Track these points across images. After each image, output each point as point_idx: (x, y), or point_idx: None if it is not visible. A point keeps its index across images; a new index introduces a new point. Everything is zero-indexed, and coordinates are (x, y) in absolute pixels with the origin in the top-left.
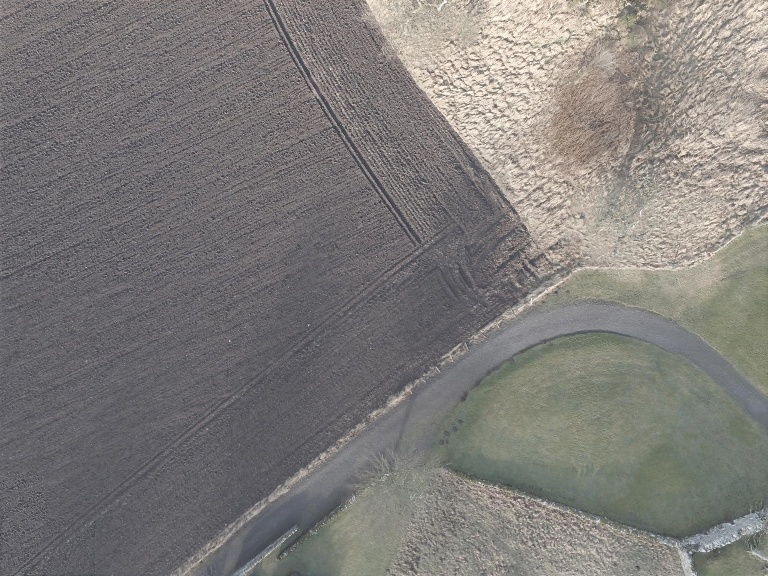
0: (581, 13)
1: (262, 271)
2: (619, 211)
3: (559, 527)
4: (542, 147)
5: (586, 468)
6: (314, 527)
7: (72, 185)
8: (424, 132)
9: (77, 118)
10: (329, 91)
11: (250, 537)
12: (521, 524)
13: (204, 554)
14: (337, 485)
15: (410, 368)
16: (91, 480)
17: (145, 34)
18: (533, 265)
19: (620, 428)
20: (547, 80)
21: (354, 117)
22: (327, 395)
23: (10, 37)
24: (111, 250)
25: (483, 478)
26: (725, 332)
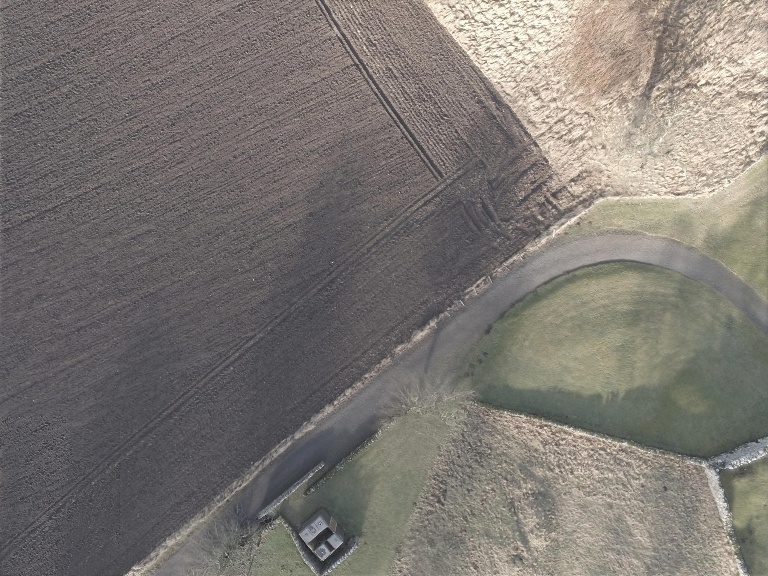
0: None
1: (285, 209)
2: (640, 140)
3: (586, 452)
4: (563, 78)
5: (611, 394)
6: (340, 463)
7: (93, 128)
8: (445, 67)
9: (97, 61)
10: (350, 29)
11: (276, 475)
12: (548, 452)
13: (230, 492)
14: (363, 421)
15: (434, 303)
16: (115, 421)
17: None
18: (555, 198)
19: (644, 353)
20: (568, 11)
21: (375, 54)
22: (352, 331)
23: None
24: (133, 192)
25: (509, 408)
26: (746, 257)
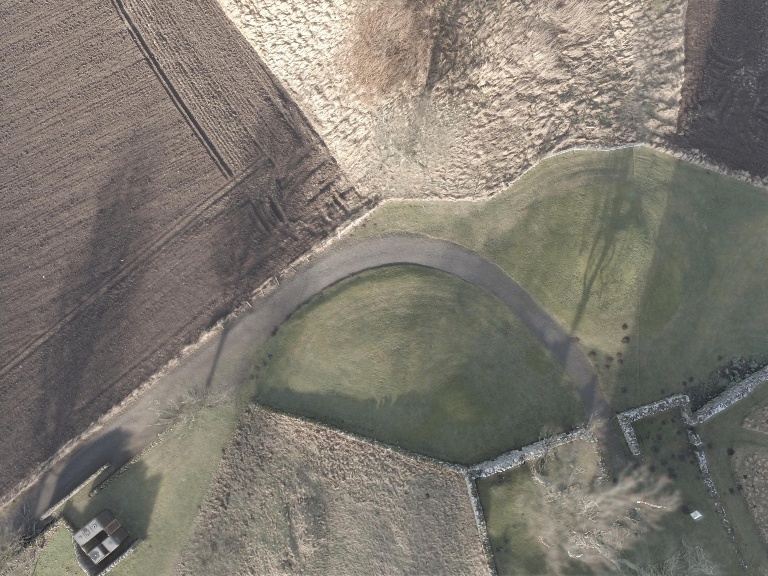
0: None
1: (76, 206)
2: None
3: (357, 458)
4: (345, 77)
5: (385, 399)
6: (125, 464)
7: None
8: (233, 63)
9: None
10: (141, 22)
11: (63, 476)
12: (323, 456)
13: (16, 493)
14: (150, 422)
15: (222, 303)
16: None
17: None
18: (343, 198)
19: (418, 358)
20: (347, 8)
21: (165, 48)
22: (140, 331)
23: None
24: None
25: (288, 411)
26: (522, 262)
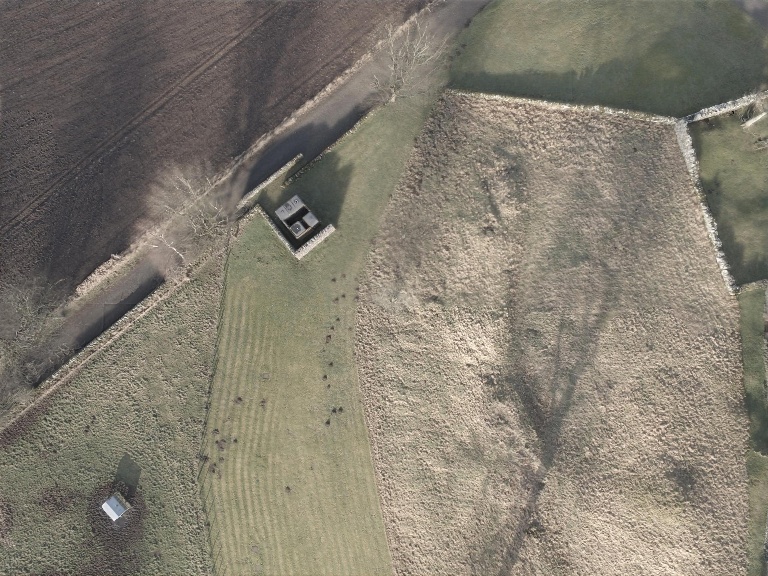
0: None
1: None
2: None
3: (559, 126)
4: None
5: (586, 70)
6: None
7: None
8: None
9: None
10: None
11: (256, 170)
12: (521, 130)
13: None
14: (342, 116)
15: None
16: (100, 118)
17: None
18: None
19: (619, 29)
20: None
21: None
22: (334, 29)
23: None
24: None
25: None
26: None
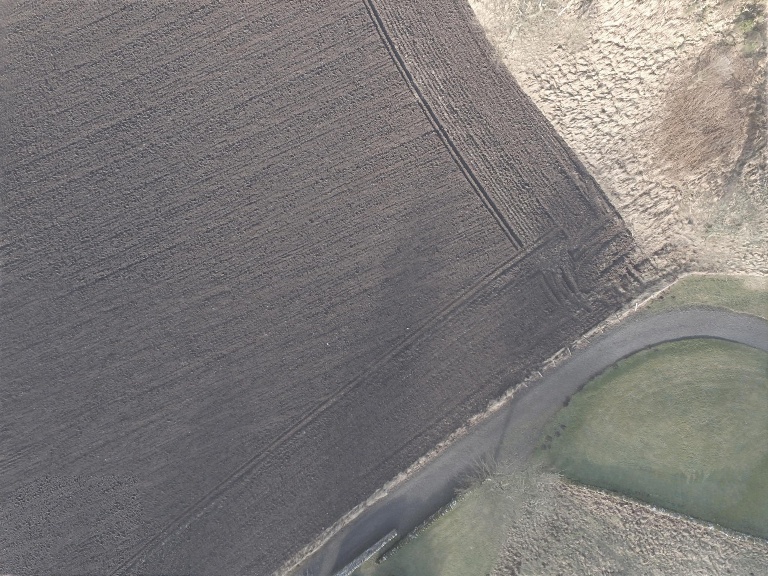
0: (697, 18)
1: (361, 274)
2: (729, 217)
3: (668, 533)
4: (651, 152)
5: (695, 474)
6: (413, 531)
7: (168, 187)
8: (528, 136)
9: (173, 120)
10: (431, 95)
11: (347, 541)
12: (628, 530)
13: (301, 558)
14: (436, 489)
15: (511, 372)
16: (187, 483)
17: (243, 37)
18: (637, 270)
19: (731, 434)
20: (658, 85)
21: (457, 121)
22: (426, 399)
23: (105, 39)
24: (208, 252)
25: (588, 483)
26: None
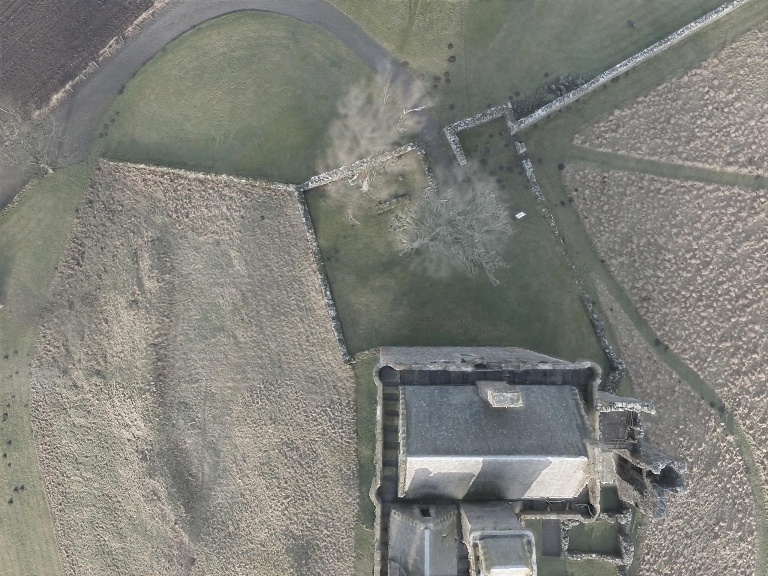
0: None
1: None
2: None
3: (198, 194)
4: None
5: (223, 135)
6: None
7: None
8: None
9: None
10: None
11: None
12: (167, 199)
13: None
14: (6, 189)
15: (71, 67)
16: None
17: None
18: None
19: (253, 93)
20: None
21: None
22: None
23: None
24: None
25: (135, 161)
26: None
